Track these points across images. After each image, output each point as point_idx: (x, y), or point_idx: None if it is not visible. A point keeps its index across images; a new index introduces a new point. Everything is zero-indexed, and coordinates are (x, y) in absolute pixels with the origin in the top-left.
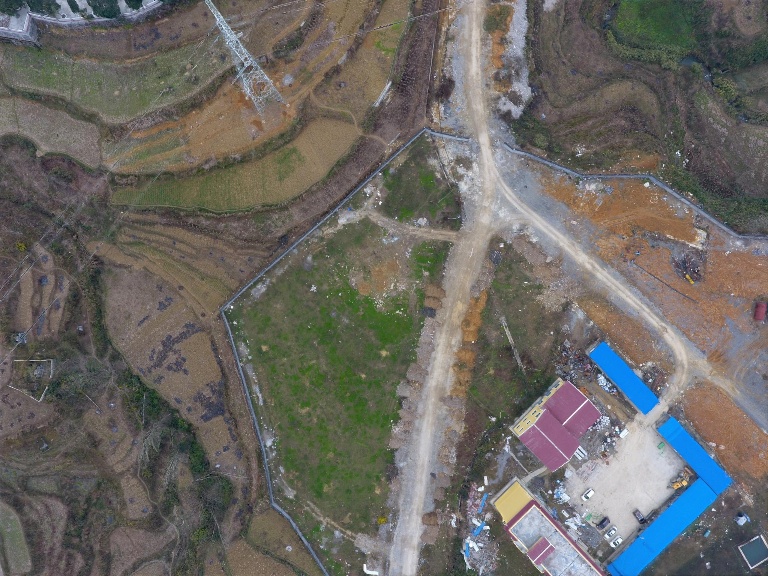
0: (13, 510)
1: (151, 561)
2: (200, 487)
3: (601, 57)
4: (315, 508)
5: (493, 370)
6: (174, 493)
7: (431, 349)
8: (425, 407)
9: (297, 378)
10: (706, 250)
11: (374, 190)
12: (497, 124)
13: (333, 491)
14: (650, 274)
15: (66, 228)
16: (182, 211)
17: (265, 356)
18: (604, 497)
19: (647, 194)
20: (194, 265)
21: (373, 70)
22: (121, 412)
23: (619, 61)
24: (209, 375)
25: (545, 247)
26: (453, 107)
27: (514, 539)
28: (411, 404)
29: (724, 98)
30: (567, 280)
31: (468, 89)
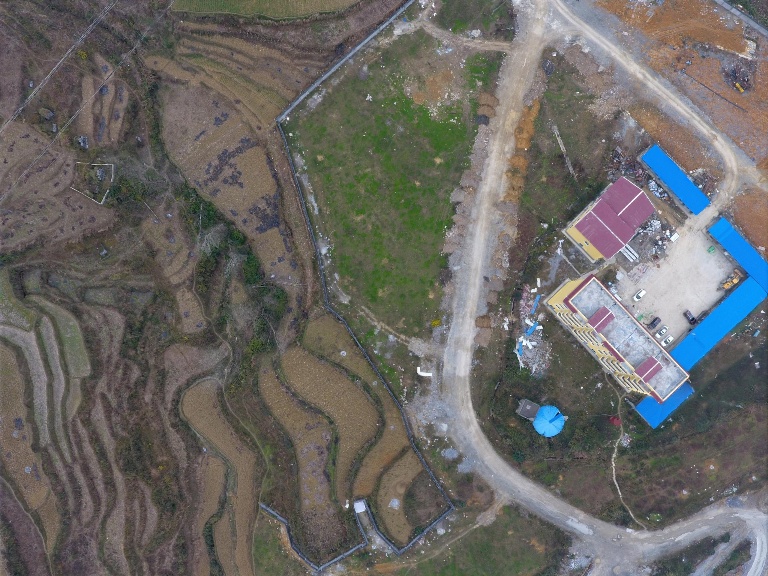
0: (73, 316)
1: (204, 378)
2: (254, 301)
3: None
4: (370, 313)
5: (545, 177)
6: (228, 309)
7: (485, 155)
8: (479, 212)
9: (352, 186)
10: (756, 60)
11: (429, 2)
12: None
13: (387, 296)
14: (700, 83)
15: (125, 42)
16: (241, 18)
17: (321, 166)
18: (655, 299)
19: (698, 6)
20: (251, 77)
21: None
22: (178, 223)
23: None
24: (264, 188)
25: (597, 57)
26: None
27: (574, 311)
28: (465, 208)
29: None
30: (619, 89)
31: None
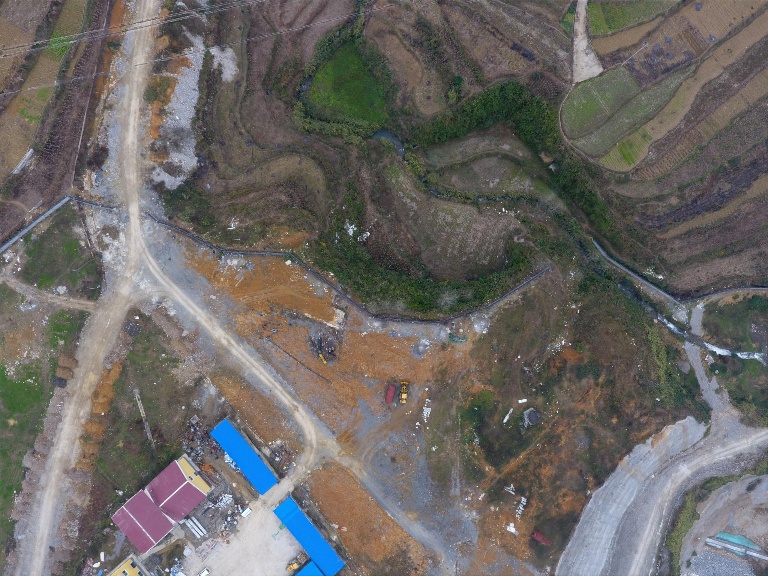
0: None
1: None
2: None
3: (281, 129)
4: None
5: (122, 443)
6: None
7: (57, 420)
8: (48, 479)
9: None
10: (343, 330)
11: (14, 256)
12: (148, 194)
13: None
14: (285, 352)
15: None
16: None
17: None
18: None
19: (288, 272)
20: None
21: (15, 137)
22: None
23: (298, 134)
24: None
25: (182, 321)
26: (106, 175)
27: None
28: (32, 475)
29: (413, 173)
30: (201, 355)
31: (122, 158)
